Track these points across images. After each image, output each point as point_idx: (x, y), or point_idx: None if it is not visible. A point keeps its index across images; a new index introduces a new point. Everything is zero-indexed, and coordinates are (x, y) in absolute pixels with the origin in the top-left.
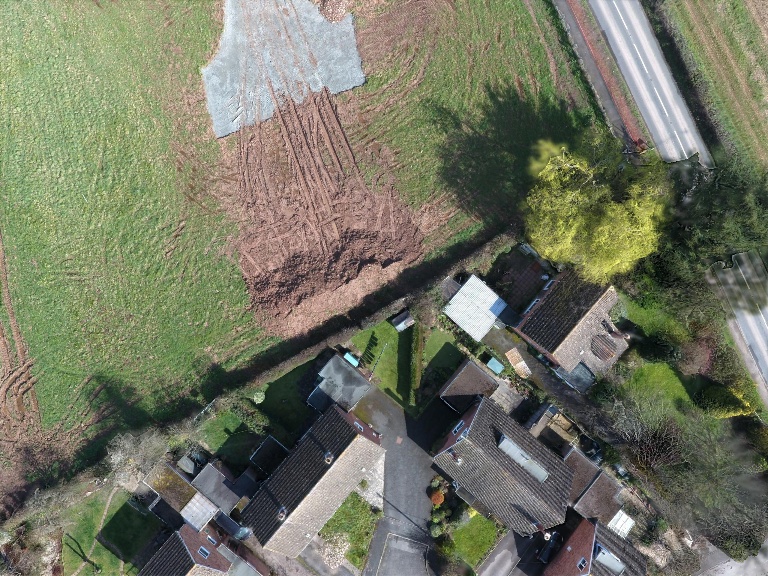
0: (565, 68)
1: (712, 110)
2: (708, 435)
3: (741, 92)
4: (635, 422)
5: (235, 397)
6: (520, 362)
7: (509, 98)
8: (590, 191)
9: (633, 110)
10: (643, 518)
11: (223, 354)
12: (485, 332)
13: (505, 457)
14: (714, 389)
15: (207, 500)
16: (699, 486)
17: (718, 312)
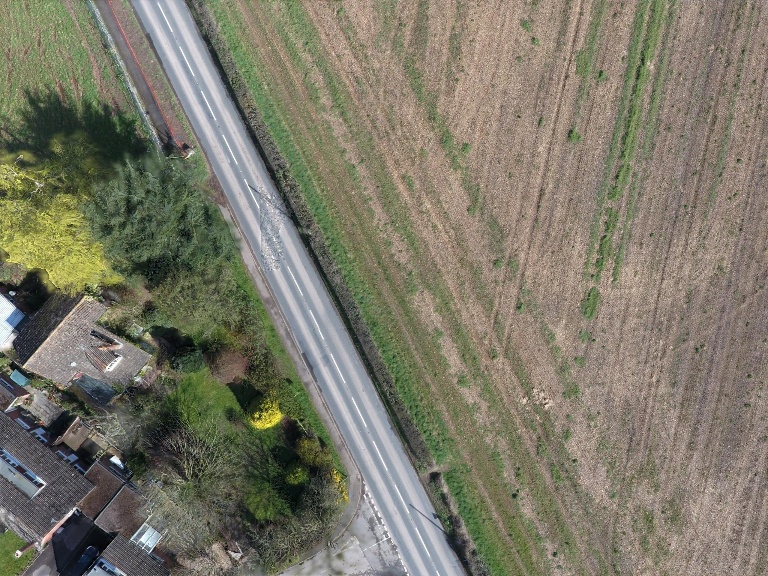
0: (108, 72)
1: (251, 113)
2: (260, 445)
3: (296, 94)
4: (180, 433)
5: None
6: None
7: (50, 103)
8: (39, 200)
9: (178, 114)
10: (190, 531)
11: None
12: (1, 344)
13: None
14: (256, 398)
15: None
16: (250, 497)
17: (249, 320)
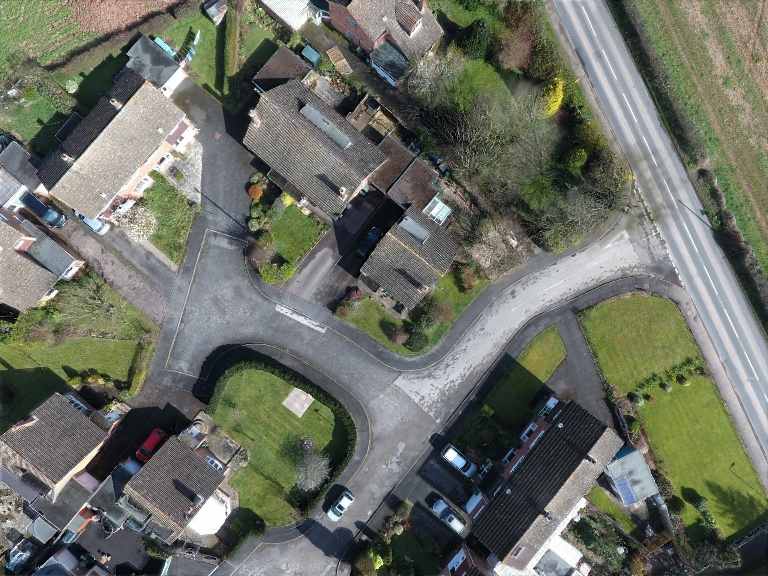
0: None
1: None
2: (534, 138)
3: None
4: (458, 122)
5: (41, 76)
6: (341, 60)
7: None
8: None
9: None
10: (467, 218)
11: (38, 49)
12: (297, 16)
13: (305, 120)
14: (536, 85)
15: (11, 176)
16: (524, 188)
17: (536, 1)
